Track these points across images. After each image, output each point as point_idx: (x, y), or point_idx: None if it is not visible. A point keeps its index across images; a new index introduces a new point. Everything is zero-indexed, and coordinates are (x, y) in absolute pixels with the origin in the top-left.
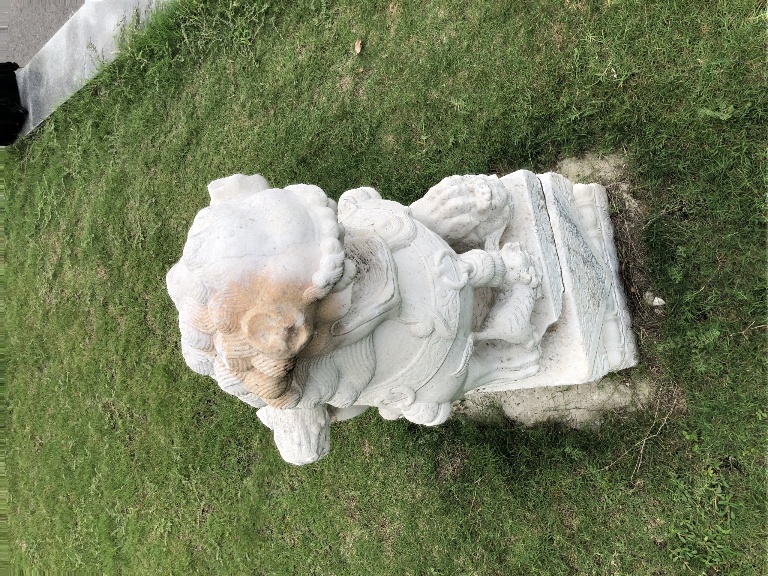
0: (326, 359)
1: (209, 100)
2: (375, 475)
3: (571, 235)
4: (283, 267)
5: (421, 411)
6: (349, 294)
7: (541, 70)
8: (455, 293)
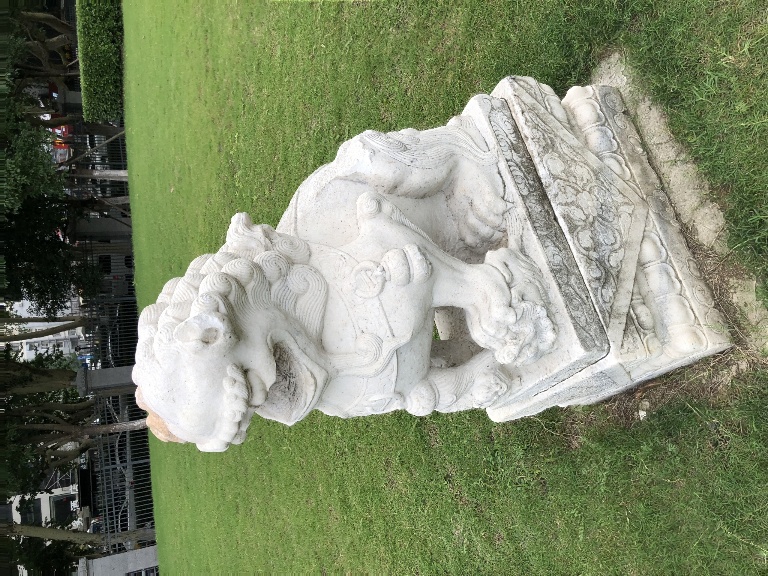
0: None
1: None
2: None
3: (591, 382)
4: None
5: None
6: None
7: None
8: None
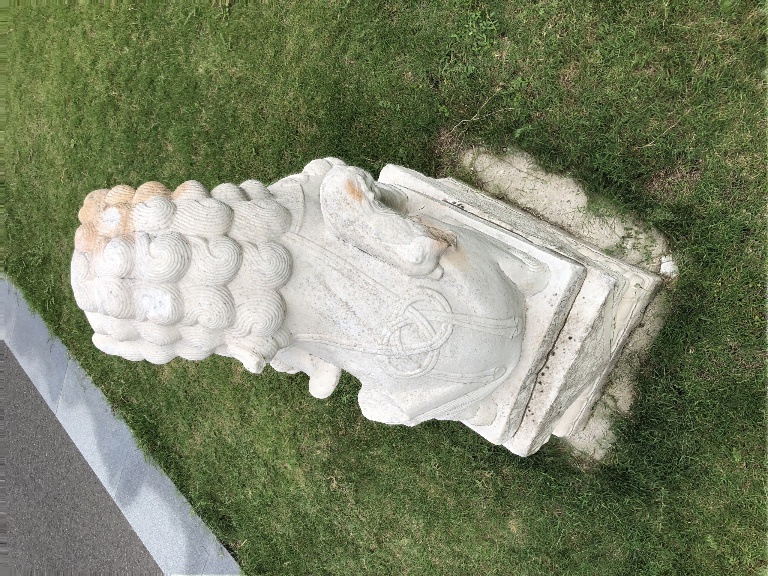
0: None
1: None
2: None
3: None
4: None
5: None
6: None
7: None
8: None
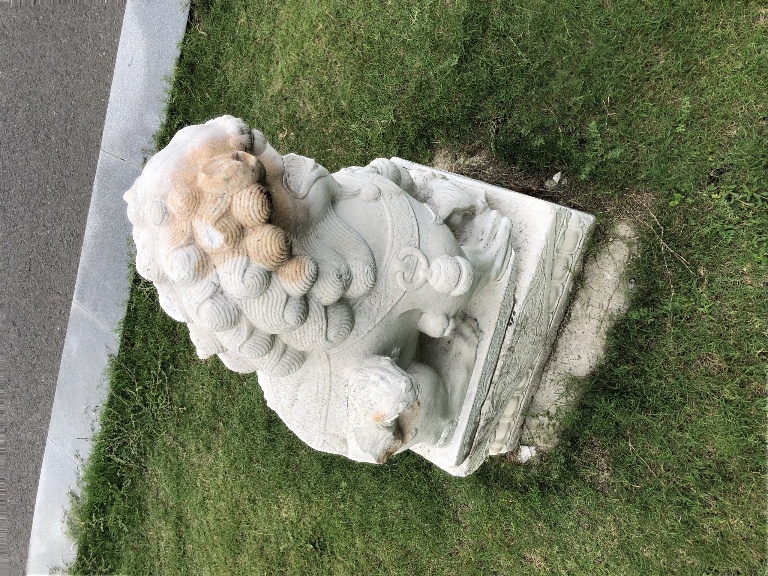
0: (314, 240)
1: (170, 482)
2: (568, 572)
3: None
4: (199, 137)
5: (441, 264)
6: (272, 149)
7: None
8: (374, 174)
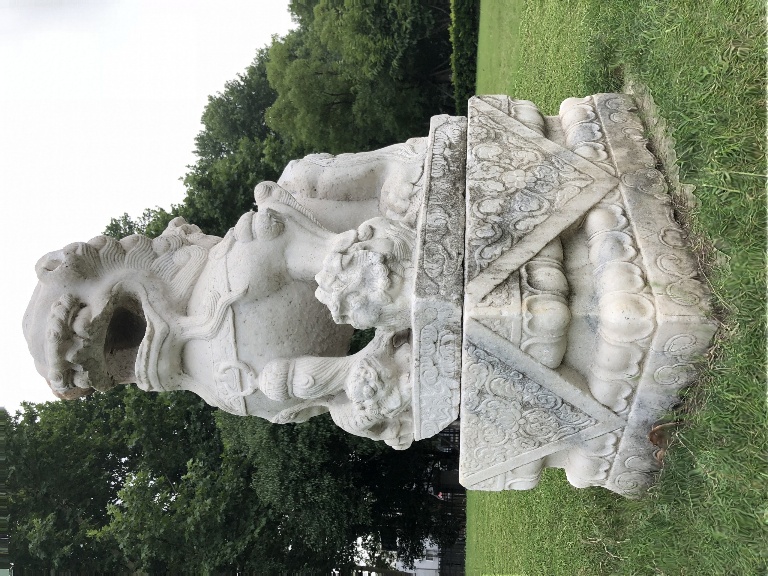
0: None
1: None
2: None
3: (500, 381)
4: None
5: None
6: None
7: (761, 27)
8: (237, 396)
